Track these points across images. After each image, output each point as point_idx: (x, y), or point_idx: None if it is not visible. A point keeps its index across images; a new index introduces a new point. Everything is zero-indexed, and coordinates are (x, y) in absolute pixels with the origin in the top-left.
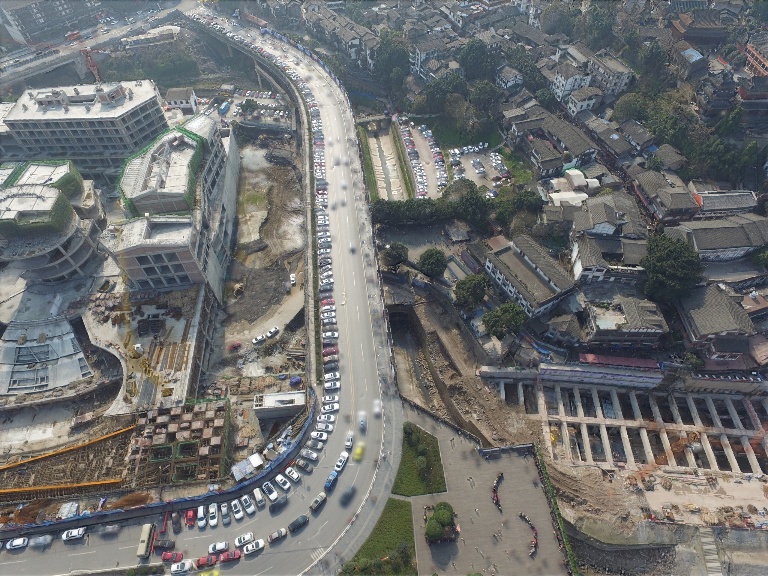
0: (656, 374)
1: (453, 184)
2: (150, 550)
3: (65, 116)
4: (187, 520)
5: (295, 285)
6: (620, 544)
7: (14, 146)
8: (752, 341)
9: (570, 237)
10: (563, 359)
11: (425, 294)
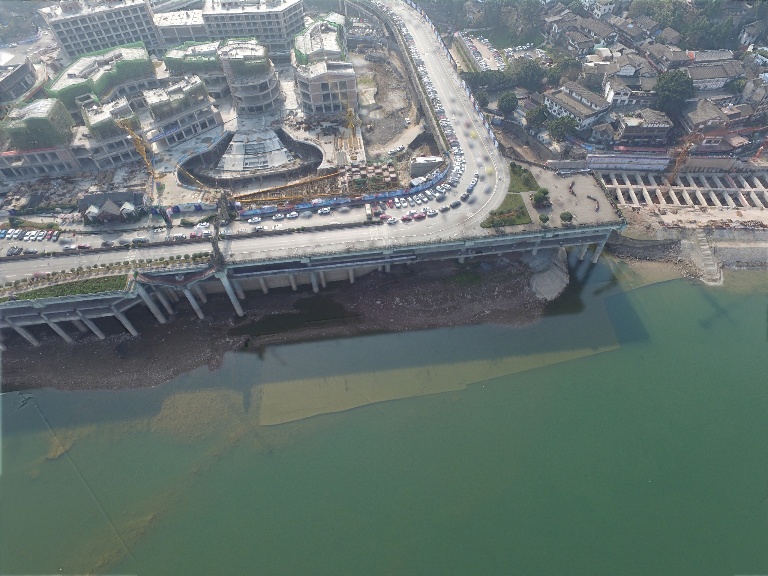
0: (666, 156)
1: (514, 61)
2: (372, 215)
3: (244, 11)
4: (389, 204)
5: (410, 124)
6: (646, 240)
7: (202, 37)
8: (730, 136)
9: (603, 85)
10: (603, 151)
11: (501, 128)
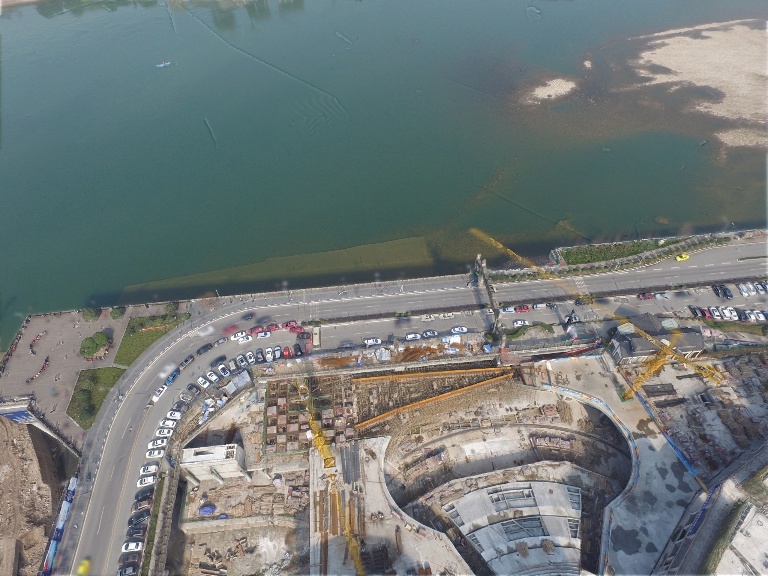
0: None
1: None
2: None
3: None
4: (289, 351)
5: None
6: None
7: None
8: None
9: None
10: None
11: None
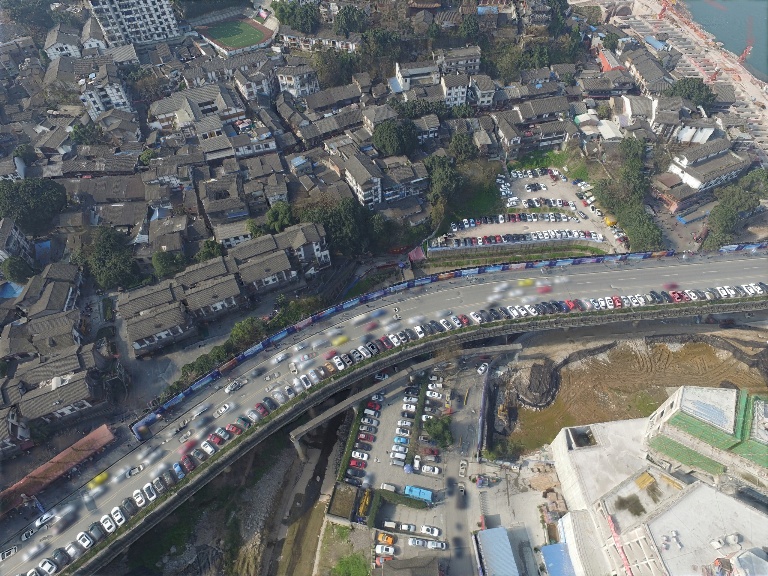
0: None
1: (608, 194)
2: None
3: None
4: None
5: None
6: None
7: None
8: None
9: None
10: None
11: None
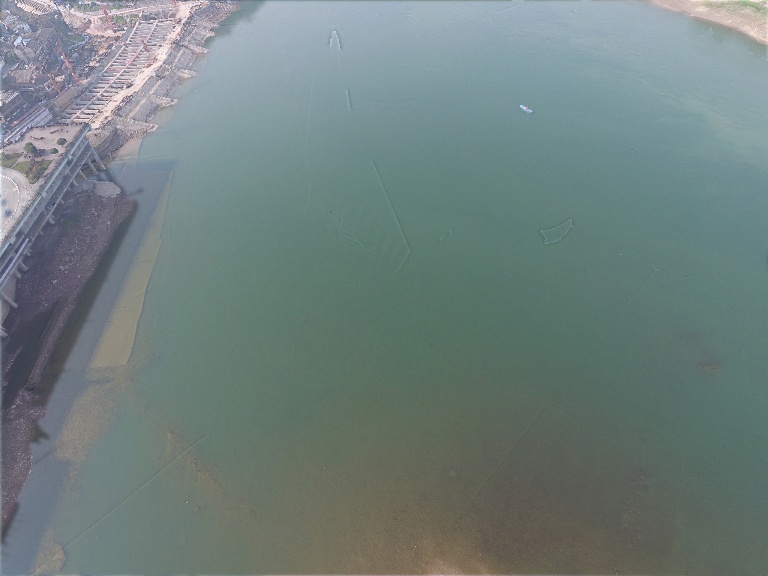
0: (43, 109)
1: None
2: None
3: None
4: None
5: None
6: (105, 140)
7: None
8: None
9: None
10: (8, 133)
11: None
